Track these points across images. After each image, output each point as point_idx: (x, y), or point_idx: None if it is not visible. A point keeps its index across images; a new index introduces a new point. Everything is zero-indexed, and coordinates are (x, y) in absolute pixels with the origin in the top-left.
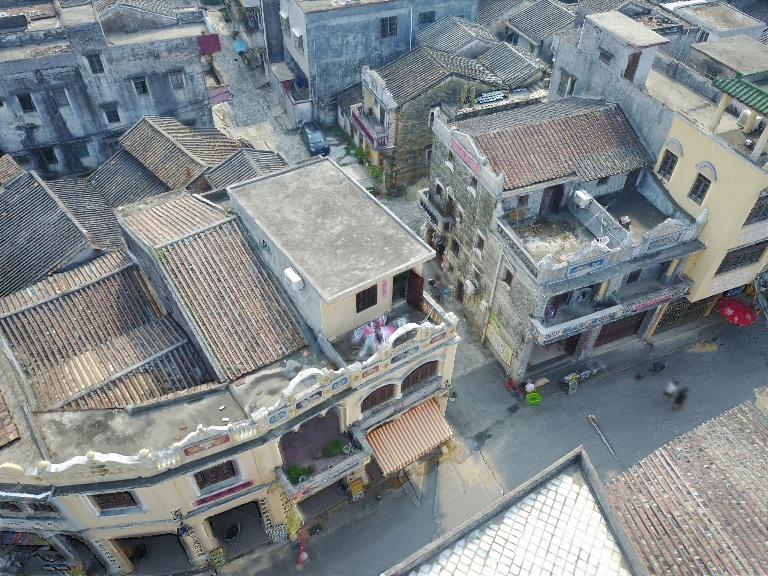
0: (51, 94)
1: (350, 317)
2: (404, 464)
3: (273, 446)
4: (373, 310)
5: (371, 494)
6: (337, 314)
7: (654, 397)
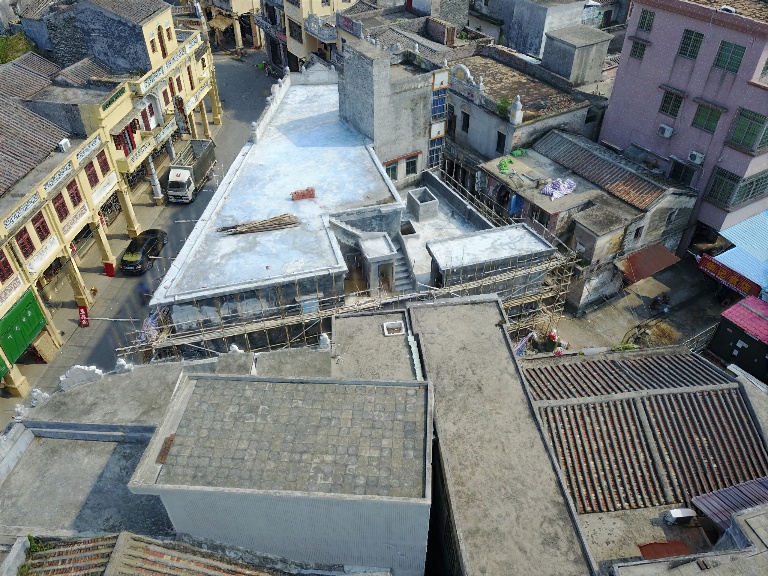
0: None
1: None
2: None
3: None
4: None
5: (218, 47)
6: None
7: None
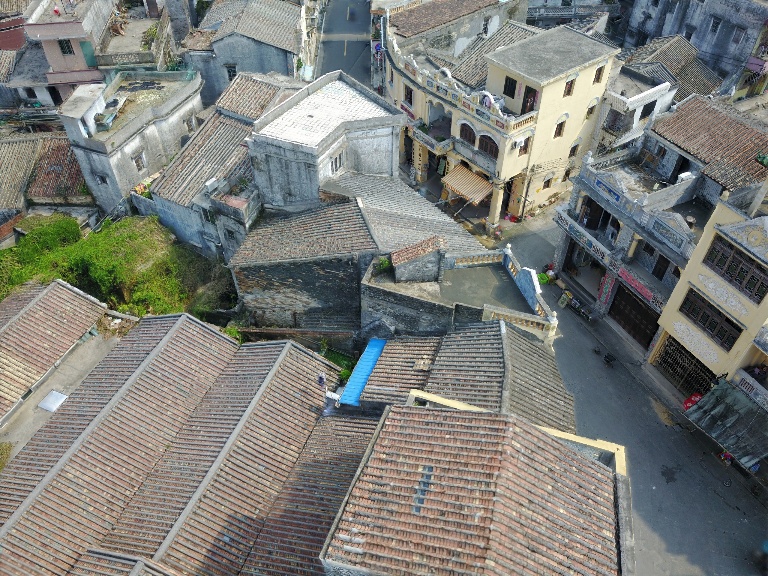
0: (670, 1)
1: (500, 92)
2: (451, 187)
3: (423, 100)
4: (512, 102)
5: (446, 209)
6: (495, 82)
7: (577, 359)
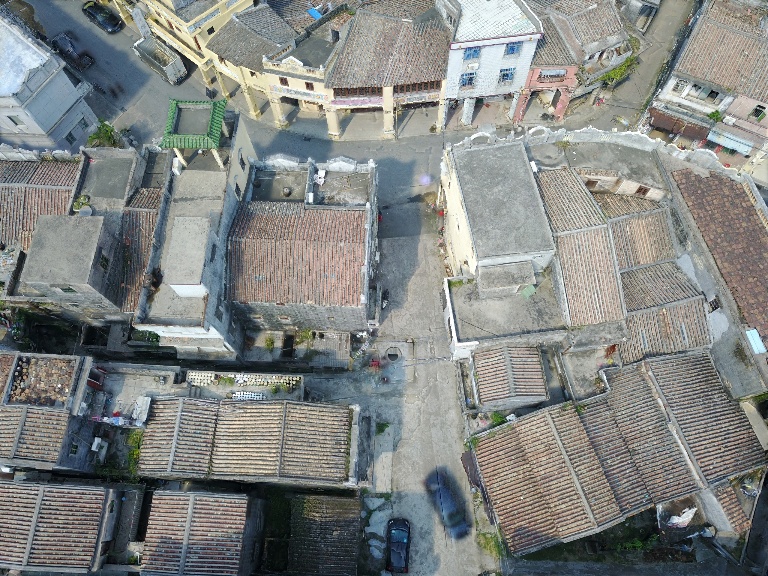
0: None
1: None
2: None
3: None
4: None
5: None
6: None
7: None
